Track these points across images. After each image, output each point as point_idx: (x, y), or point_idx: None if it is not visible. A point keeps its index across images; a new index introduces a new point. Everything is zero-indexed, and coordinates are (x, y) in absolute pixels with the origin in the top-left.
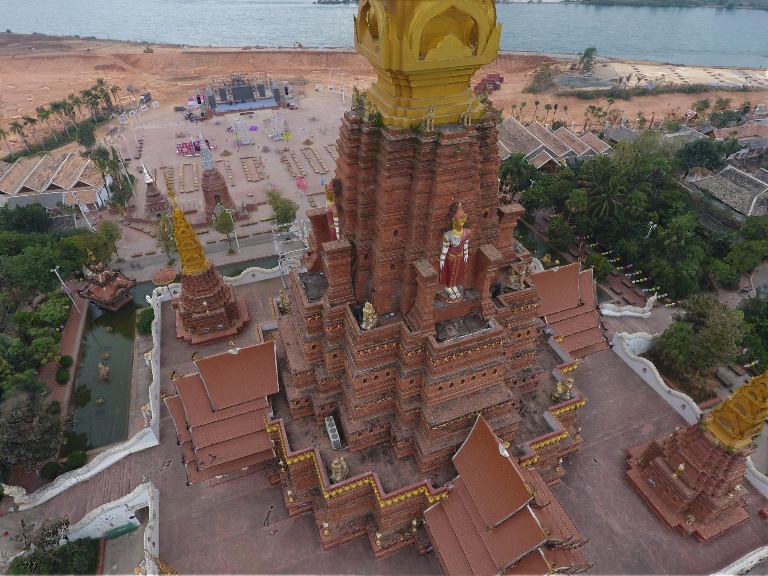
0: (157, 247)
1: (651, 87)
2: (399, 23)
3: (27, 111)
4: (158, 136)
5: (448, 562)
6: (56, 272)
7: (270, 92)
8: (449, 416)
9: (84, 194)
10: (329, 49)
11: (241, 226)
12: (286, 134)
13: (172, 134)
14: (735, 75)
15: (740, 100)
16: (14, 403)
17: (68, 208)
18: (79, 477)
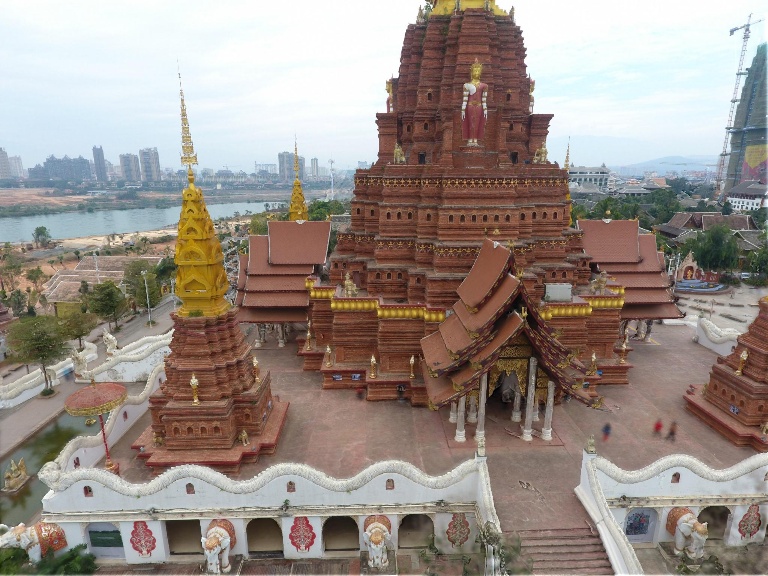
0: None
1: (132, 243)
2: None
3: None
4: None
5: (649, 300)
6: None
7: None
8: (575, 229)
9: None
10: None
11: None
12: None
13: None
14: (174, 231)
15: (215, 231)
16: None
17: None
18: None
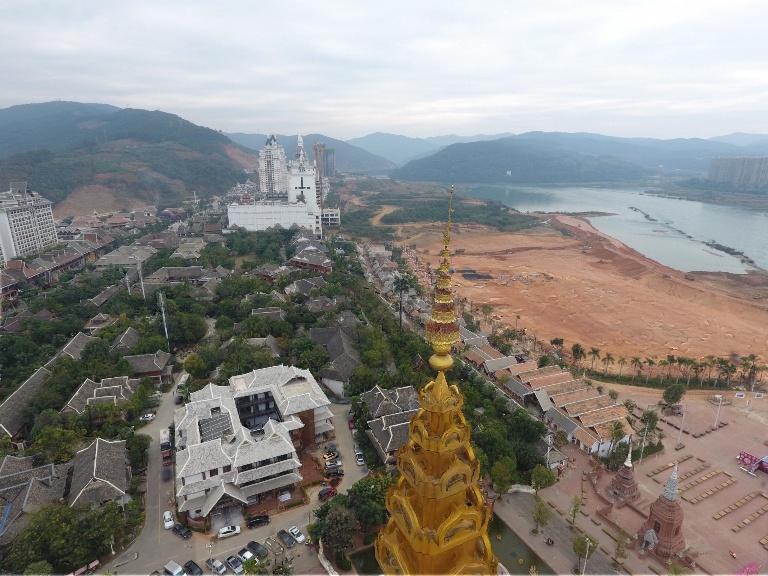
0: (532, 513)
1: None
2: None
3: (687, 347)
4: (749, 430)
5: None
6: None
7: None
8: None
9: (588, 437)
10: None
11: (649, 567)
12: None
13: (765, 438)
14: None
15: None
16: (360, 513)
17: (565, 438)
18: (330, 571)
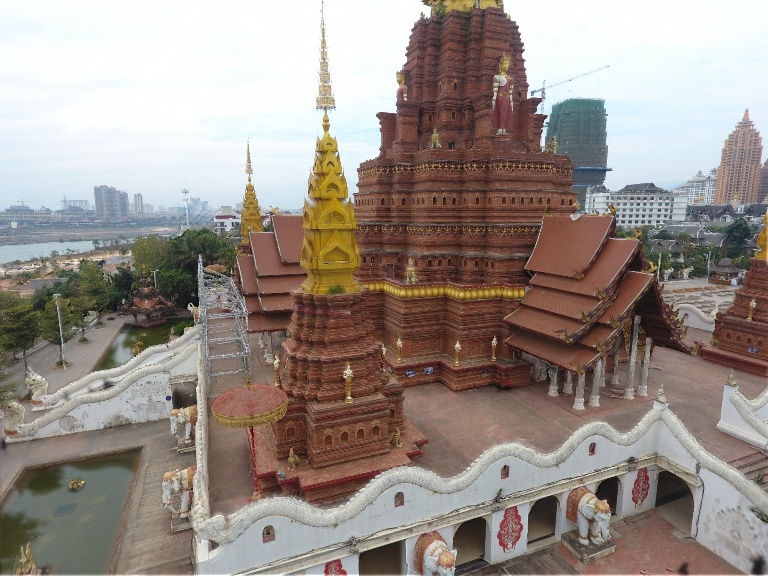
0: None
1: None
2: None
3: None
4: None
5: None
6: None
7: None
8: None
9: None
10: None
11: None
12: None
13: None
14: None
15: (48, 269)
16: None
17: None
18: None
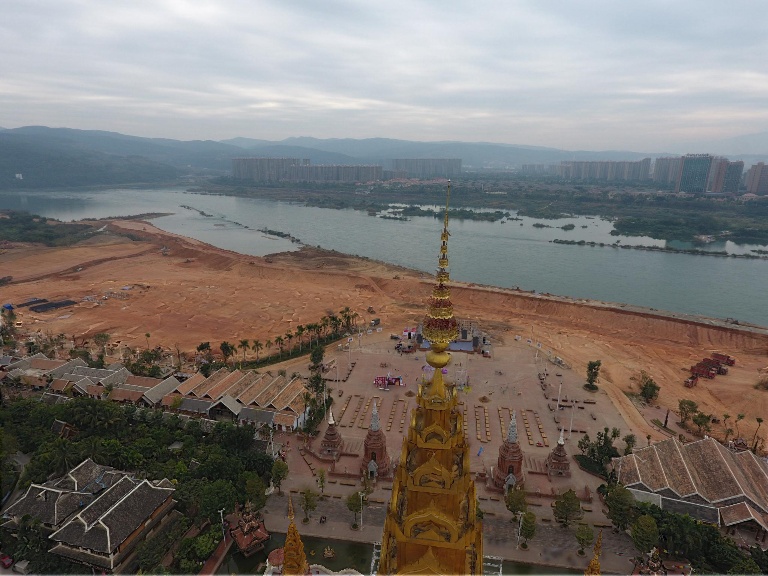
0: (300, 505)
1: None
2: (398, 557)
3: (298, 317)
4: (368, 361)
5: None
6: (221, 513)
7: (471, 336)
8: None
9: (287, 418)
10: (544, 296)
11: (383, 488)
12: (466, 387)
13: (379, 362)
14: None
15: None
16: None
17: (271, 429)
18: None
